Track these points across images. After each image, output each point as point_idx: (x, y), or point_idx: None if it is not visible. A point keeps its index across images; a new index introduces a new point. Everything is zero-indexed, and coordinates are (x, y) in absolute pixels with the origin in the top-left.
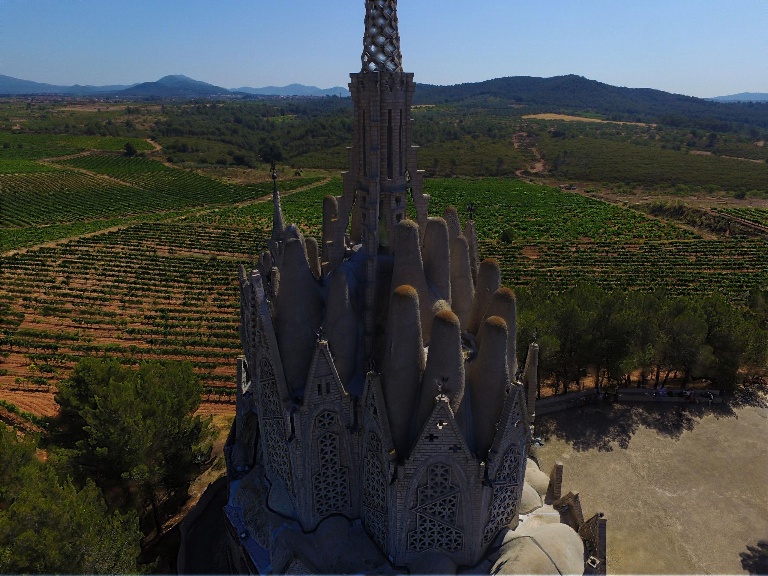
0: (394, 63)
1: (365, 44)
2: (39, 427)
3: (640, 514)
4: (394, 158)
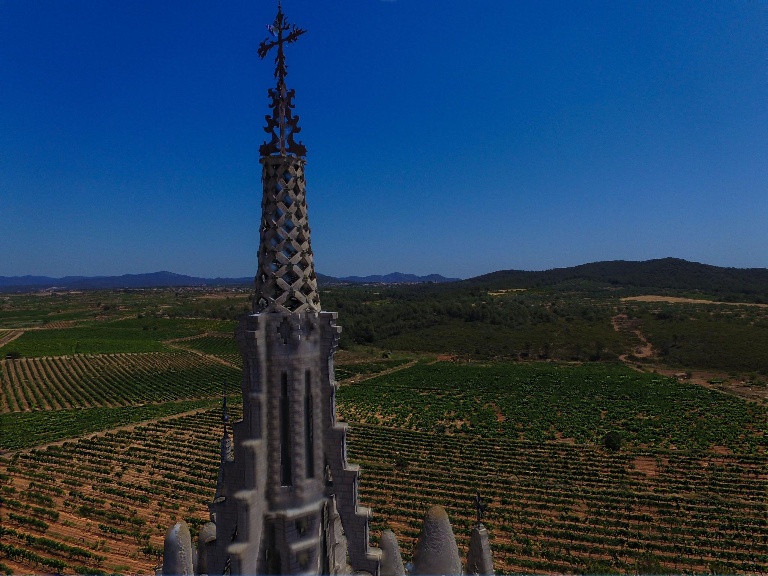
0: (295, 299)
1: (256, 273)
2: None
3: None
4: (293, 449)
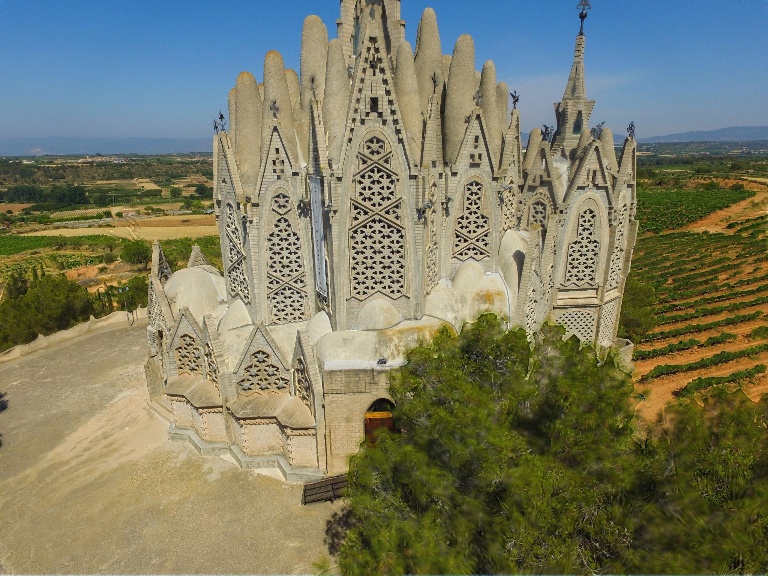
0: None
1: None
2: (738, 362)
3: (88, 571)
4: None
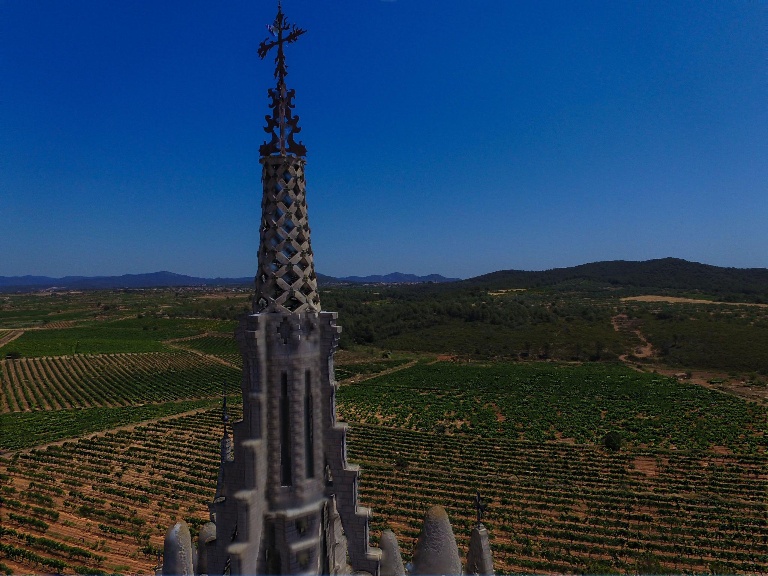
0: (295, 299)
1: (256, 273)
2: None
3: None
4: (293, 449)
